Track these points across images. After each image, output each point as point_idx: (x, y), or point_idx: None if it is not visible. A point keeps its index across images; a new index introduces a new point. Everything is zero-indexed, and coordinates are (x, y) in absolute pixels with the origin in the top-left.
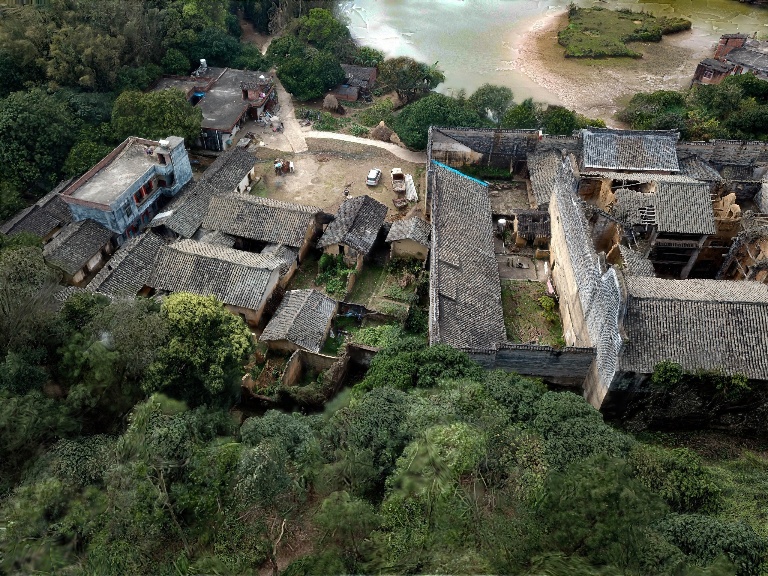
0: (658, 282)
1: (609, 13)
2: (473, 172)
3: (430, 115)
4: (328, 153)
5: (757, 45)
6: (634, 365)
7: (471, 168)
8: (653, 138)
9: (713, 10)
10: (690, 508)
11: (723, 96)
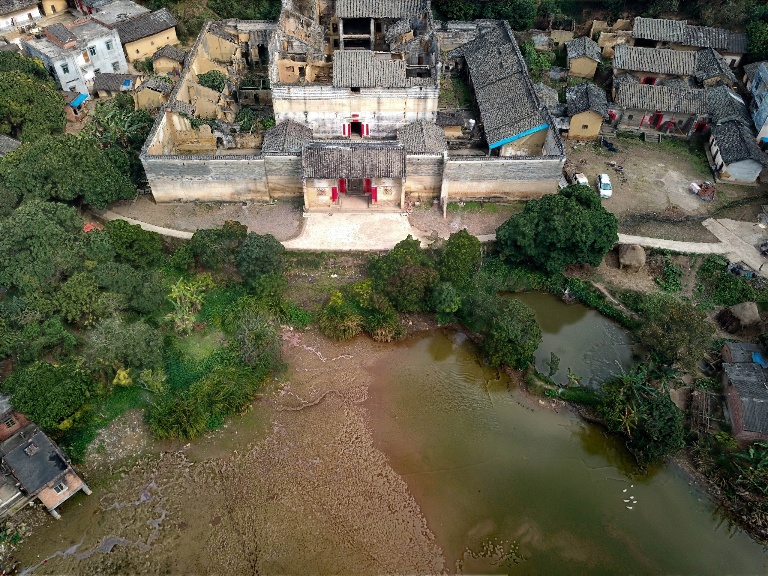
0: (397, 8)
1: None
2: None
3: None
4: (675, 219)
5: None
6: None
7: None
8: None
9: None
10: None
11: None
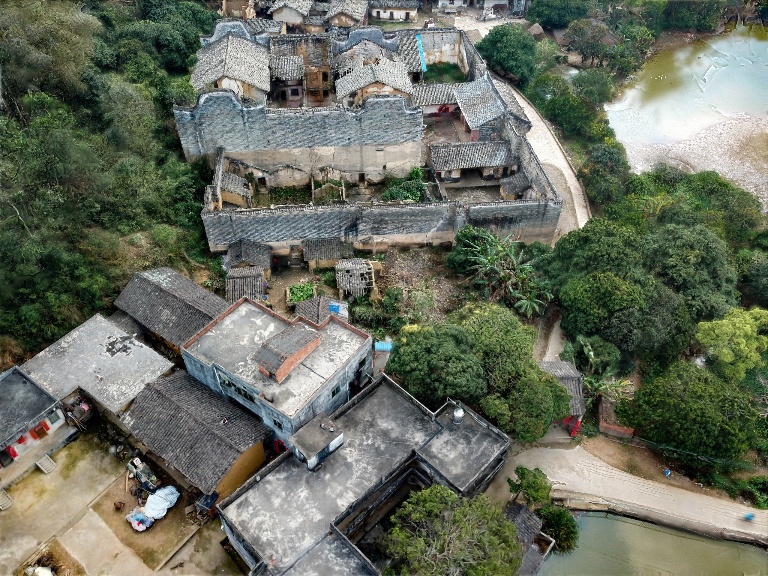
0: (258, 57)
1: None
2: (459, 78)
3: (491, 34)
4: None
5: None
6: (198, 54)
7: (461, 75)
8: None
9: None
10: (123, 69)
11: (726, 205)
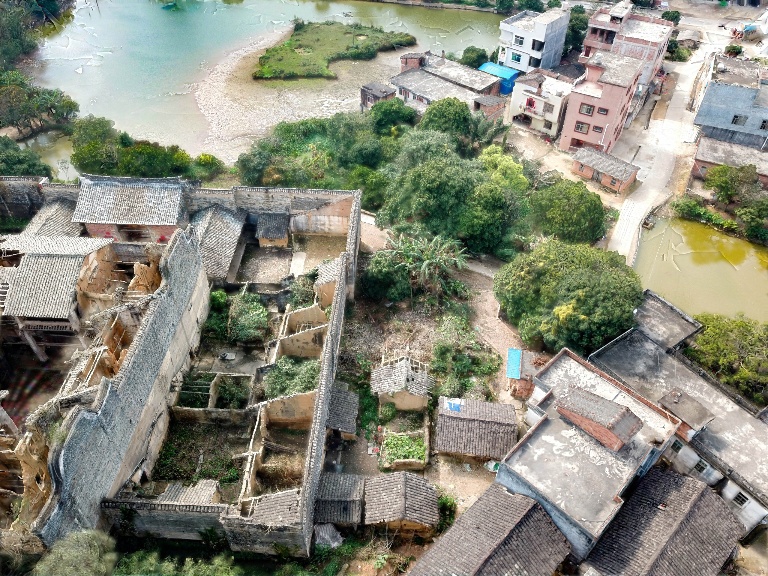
0: None
1: (337, 28)
2: None
3: None
4: None
5: (440, 65)
6: None
7: None
8: (158, 186)
9: (468, 22)
10: None
11: (348, 126)
